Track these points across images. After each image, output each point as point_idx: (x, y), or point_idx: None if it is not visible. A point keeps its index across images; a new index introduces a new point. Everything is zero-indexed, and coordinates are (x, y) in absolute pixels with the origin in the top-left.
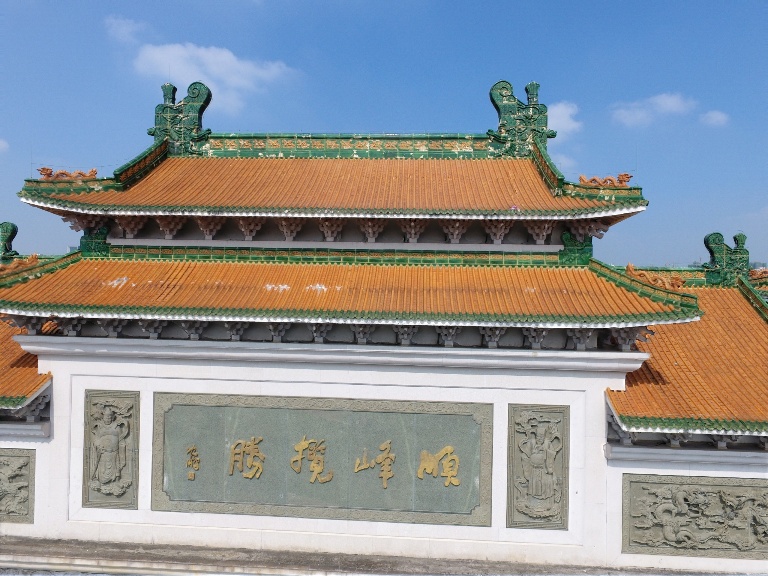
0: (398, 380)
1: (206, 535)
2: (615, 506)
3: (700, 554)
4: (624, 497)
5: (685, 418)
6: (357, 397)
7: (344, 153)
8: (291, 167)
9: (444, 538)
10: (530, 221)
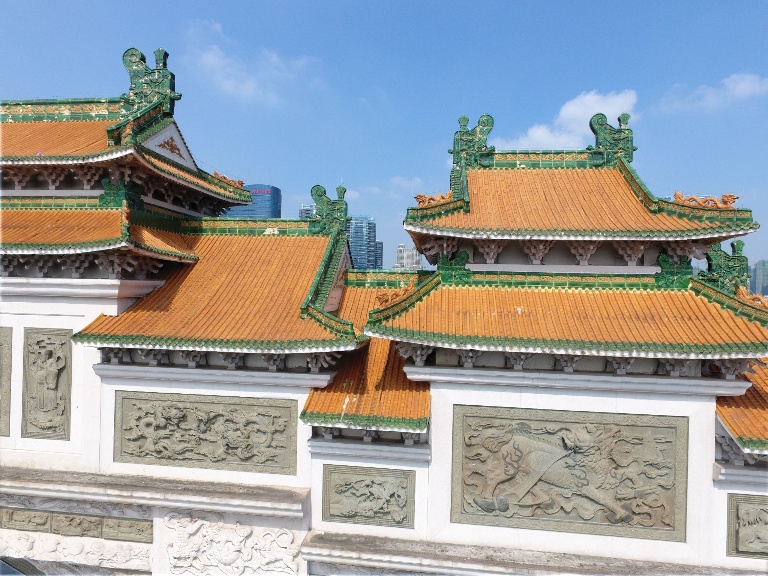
0: None
1: None
2: (108, 419)
3: (179, 464)
4: (117, 412)
5: (129, 335)
6: None
7: (1, 118)
8: None
9: None
10: None
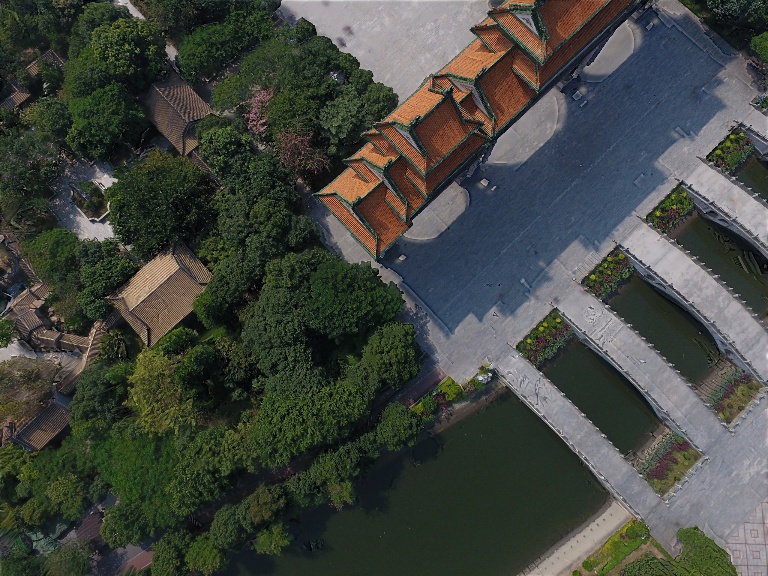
0: None
1: None
2: None
3: None
4: None
5: (469, 46)
6: None
7: None
8: None
9: None
10: None
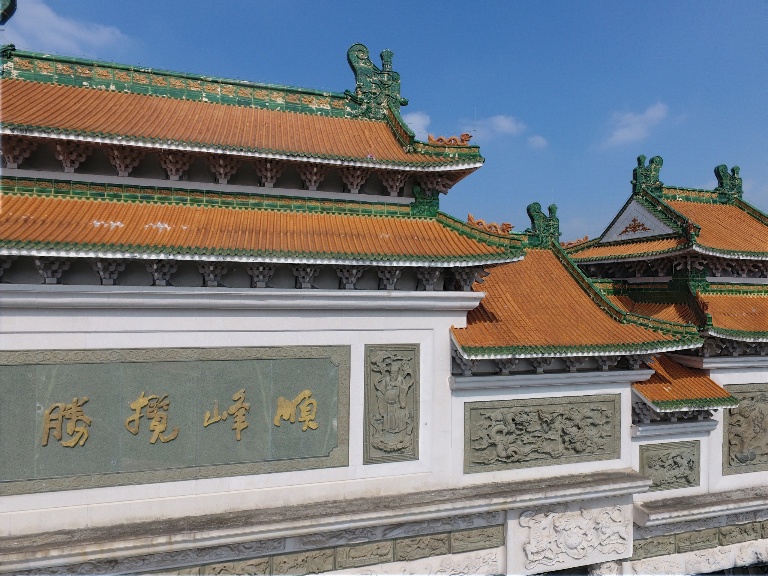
0: (253, 325)
1: (9, 522)
2: (458, 432)
3: (524, 466)
4: (465, 423)
5: (513, 346)
6: (207, 345)
7: (191, 94)
8: (126, 101)
9: (302, 484)
10: (385, 173)
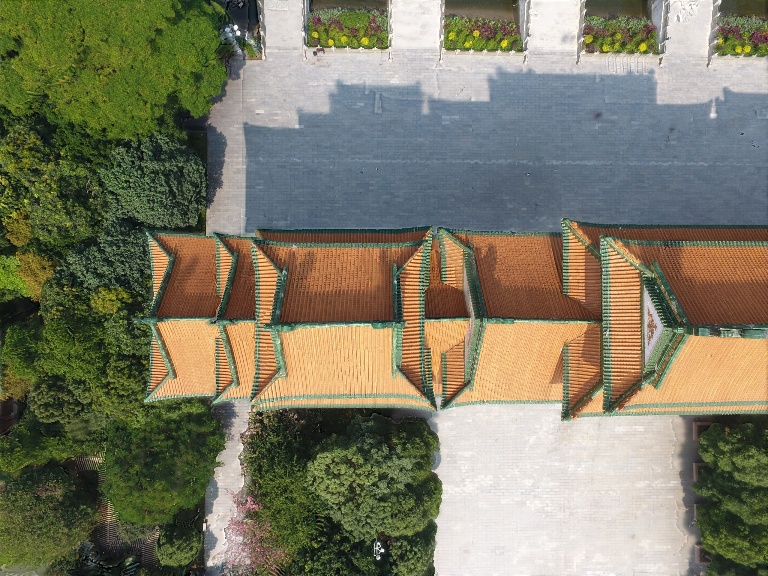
0: None
1: None
2: None
3: None
4: None
5: None
6: None
7: None
8: None
9: None
10: None
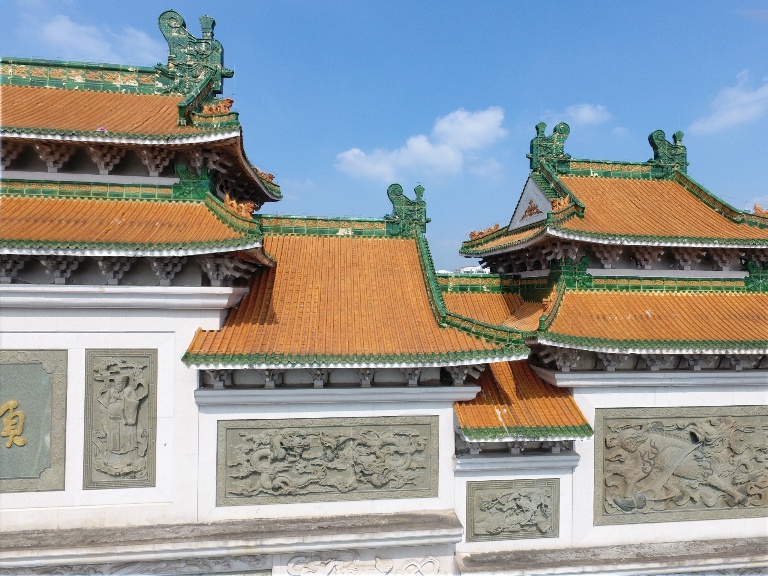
0: None
1: None
2: (208, 456)
3: (300, 500)
4: (219, 446)
5: (256, 353)
6: None
7: None
8: None
9: (6, 508)
10: (139, 150)
